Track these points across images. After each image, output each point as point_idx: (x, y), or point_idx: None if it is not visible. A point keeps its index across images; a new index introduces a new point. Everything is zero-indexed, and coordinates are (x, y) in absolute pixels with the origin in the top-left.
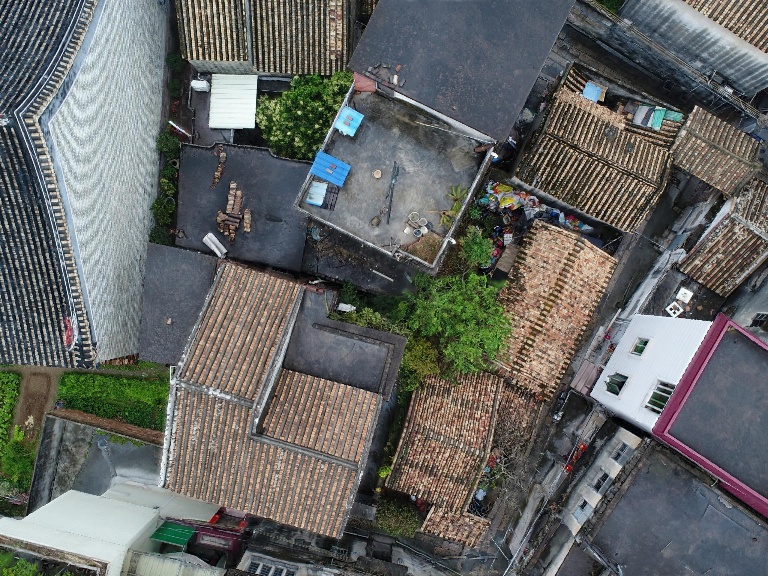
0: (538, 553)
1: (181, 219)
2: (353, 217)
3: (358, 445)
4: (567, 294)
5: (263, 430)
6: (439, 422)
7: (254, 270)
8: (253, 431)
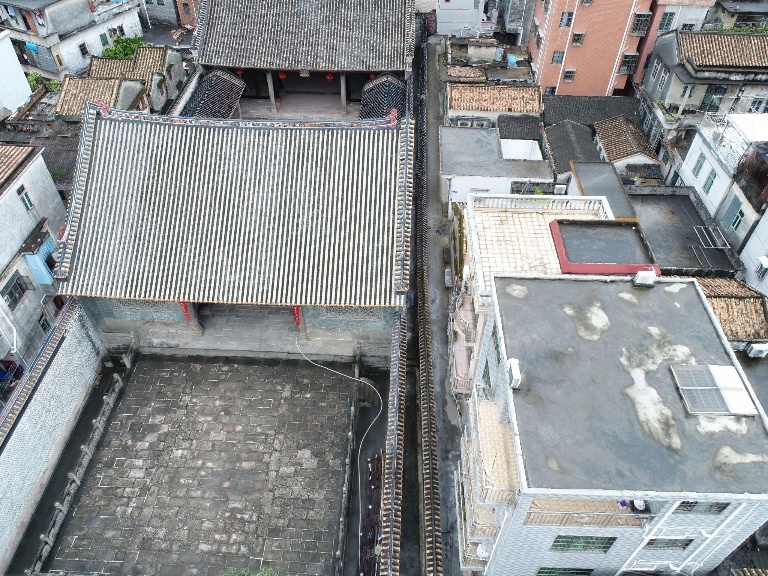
0: None
1: None
2: None
3: None
4: None
5: None
6: None
7: None
8: None
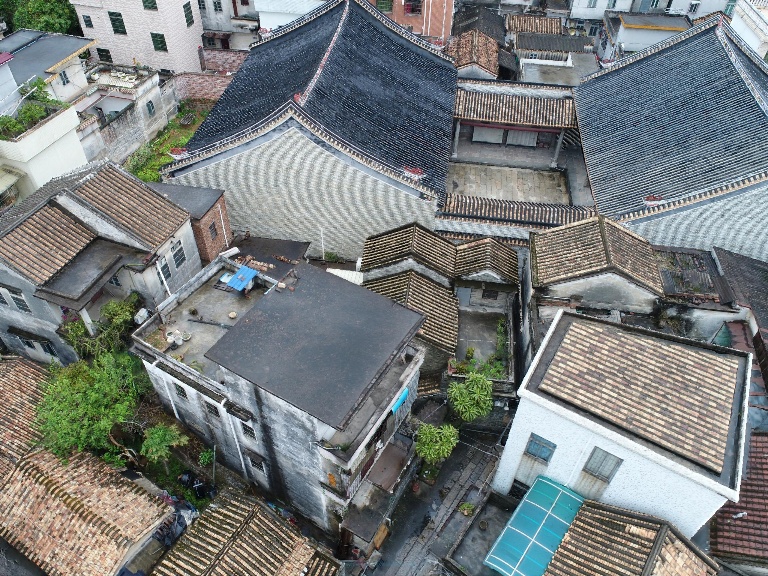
0: None
1: (256, 239)
2: (203, 299)
3: (5, 254)
4: (76, 527)
5: (51, 205)
6: (8, 385)
7: None
8: None
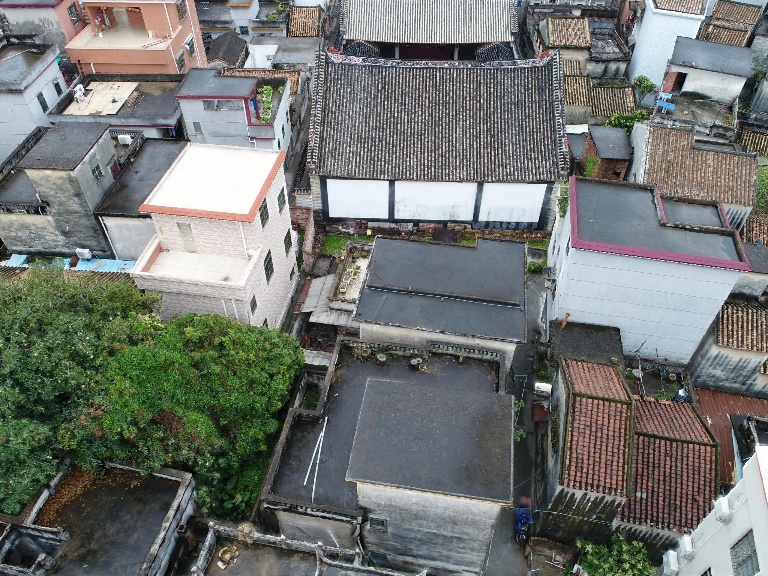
0: None
1: None
2: None
3: None
4: None
5: None
6: None
7: None
8: (693, 144)
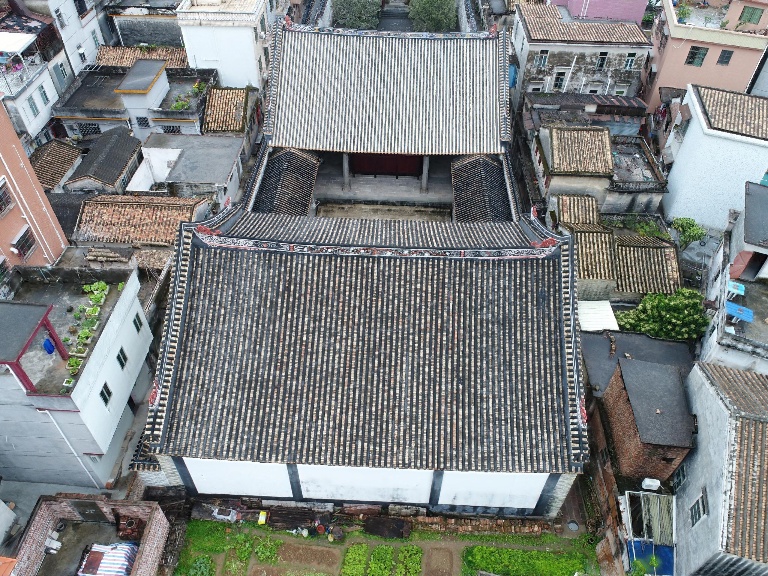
0: None
1: (592, 378)
2: None
3: None
4: None
5: None
6: None
7: None
8: None
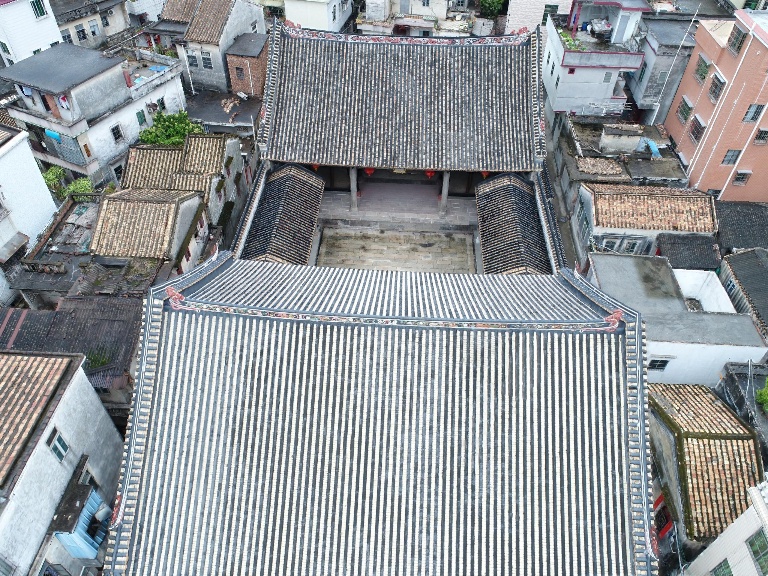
0: (122, 31)
1: (260, 104)
2: None
3: None
4: None
5: None
6: None
7: (205, 43)
8: None
